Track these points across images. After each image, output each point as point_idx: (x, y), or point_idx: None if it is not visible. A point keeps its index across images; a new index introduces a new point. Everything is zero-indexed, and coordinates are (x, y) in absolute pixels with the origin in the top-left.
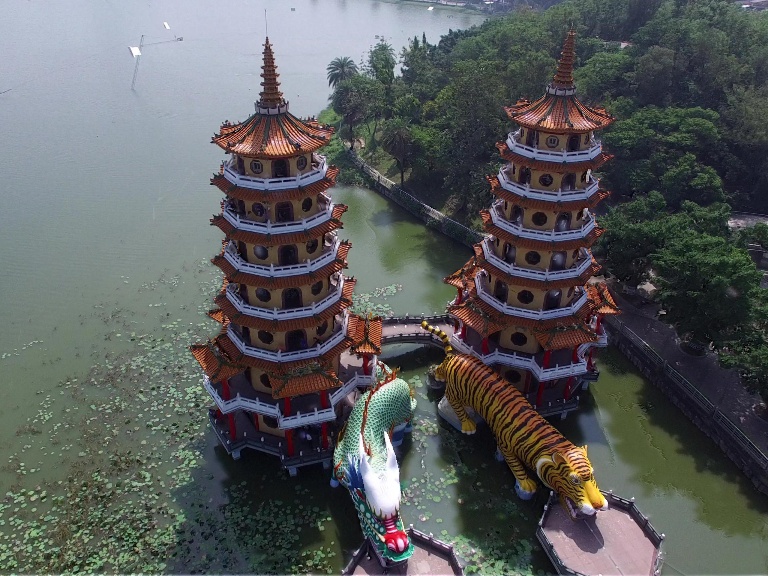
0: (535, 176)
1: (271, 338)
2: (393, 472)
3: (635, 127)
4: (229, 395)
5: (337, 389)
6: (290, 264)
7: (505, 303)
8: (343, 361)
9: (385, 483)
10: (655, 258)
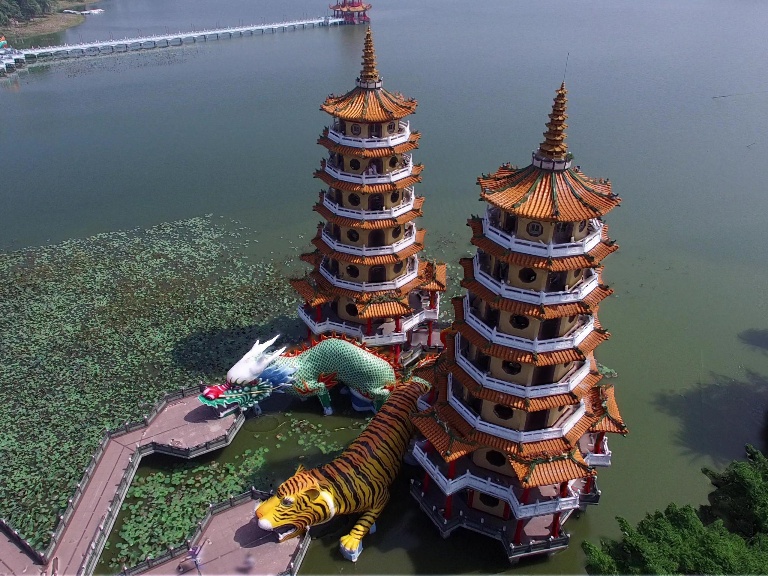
0: None
1: None
2: (255, 364)
3: None
4: None
5: (339, 322)
6: (335, 202)
7: None
8: (387, 324)
9: (244, 363)
10: None
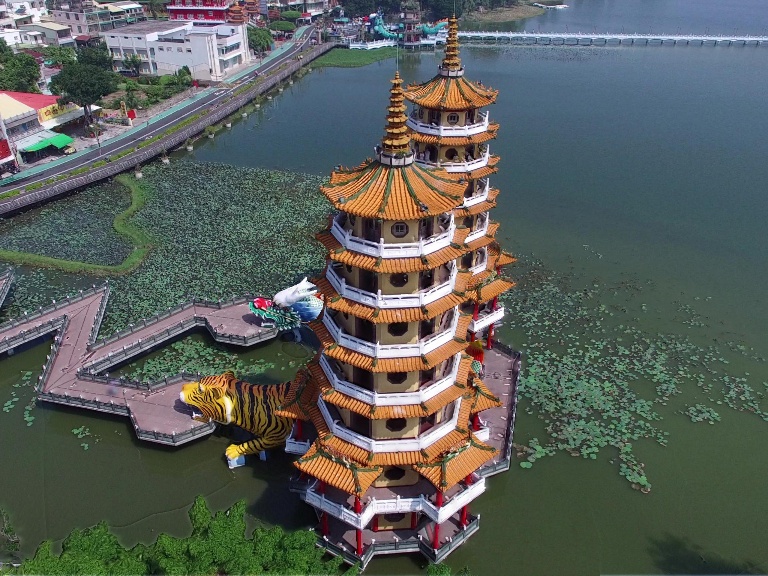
0: None
1: None
2: None
3: None
4: None
5: None
6: None
7: None
8: None
9: None
10: None
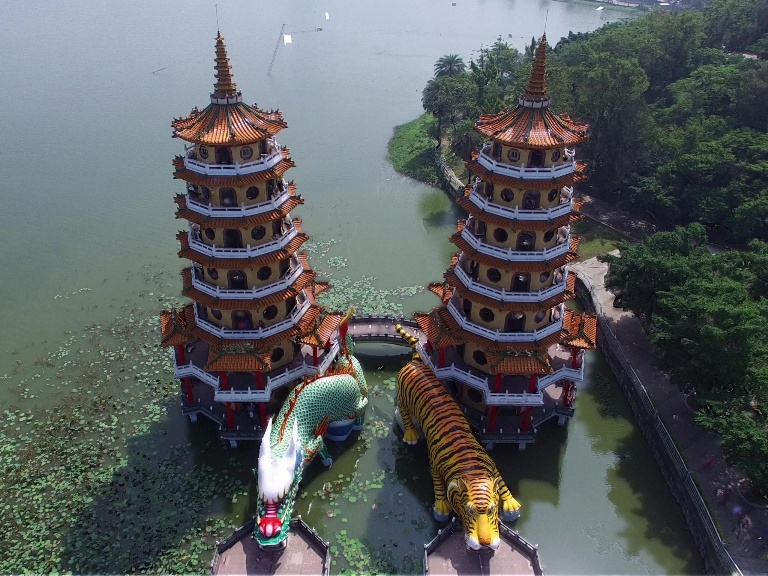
0: (497, 190)
1: (220, 314)
2: (287, 461)
3: (717, 150)
4: (184, 361)
5: (279, 374)
6: (233, 247)
7: (464, 318)
8: (304, 349)
9: (275, 469)
10: (664, 296)
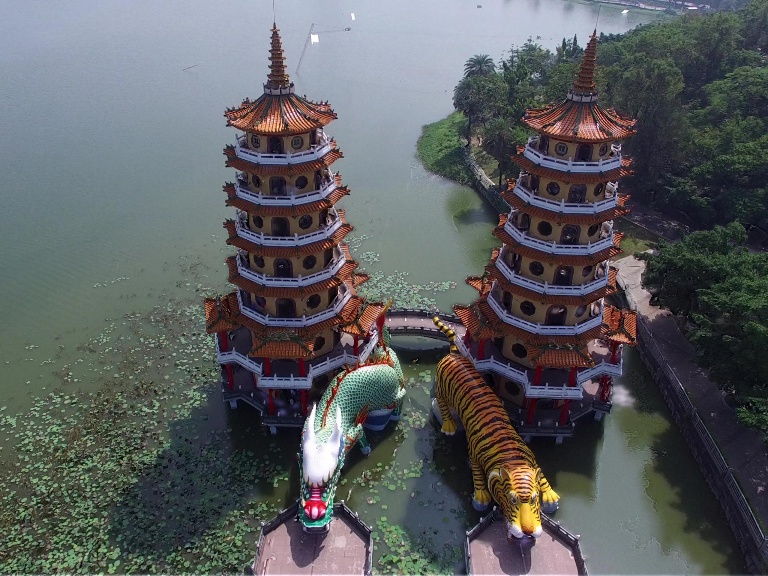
0: (543, 183)
1: (265, 302)
2: (332, 446)
3: (755, 151)
4: (227, 348)
5: (321, 362)
6: (281, 236)
7: (505, 311)
8: (344, 339)
9: (320, 454)
10: (704, 294)
